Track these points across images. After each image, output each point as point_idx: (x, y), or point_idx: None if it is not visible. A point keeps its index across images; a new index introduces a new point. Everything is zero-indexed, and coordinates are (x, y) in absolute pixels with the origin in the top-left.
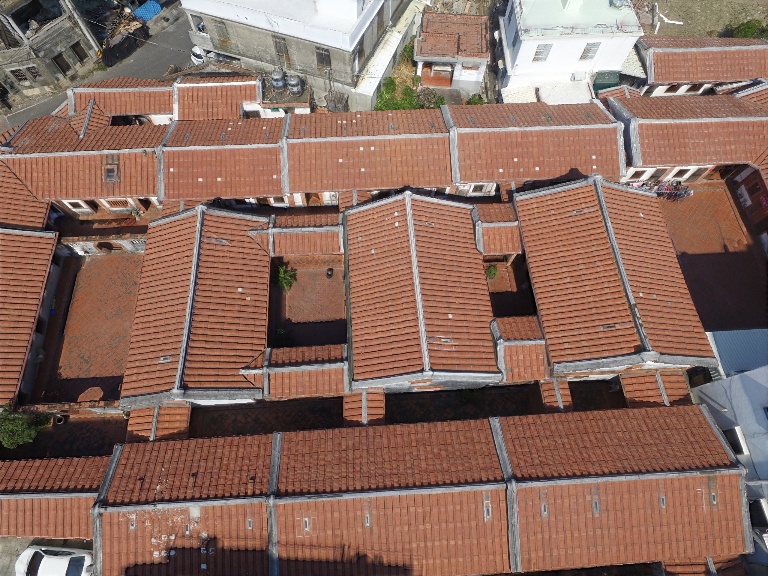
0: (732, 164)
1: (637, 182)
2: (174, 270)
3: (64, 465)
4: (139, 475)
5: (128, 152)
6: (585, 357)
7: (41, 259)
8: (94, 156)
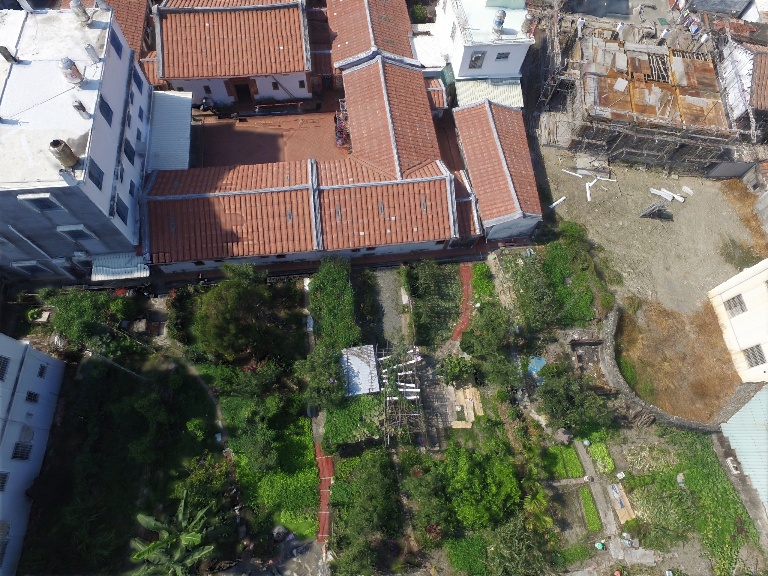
0: None
1: None
2: None
3: None
4: None
5: None
6: (170, 1)
7: None
8: None
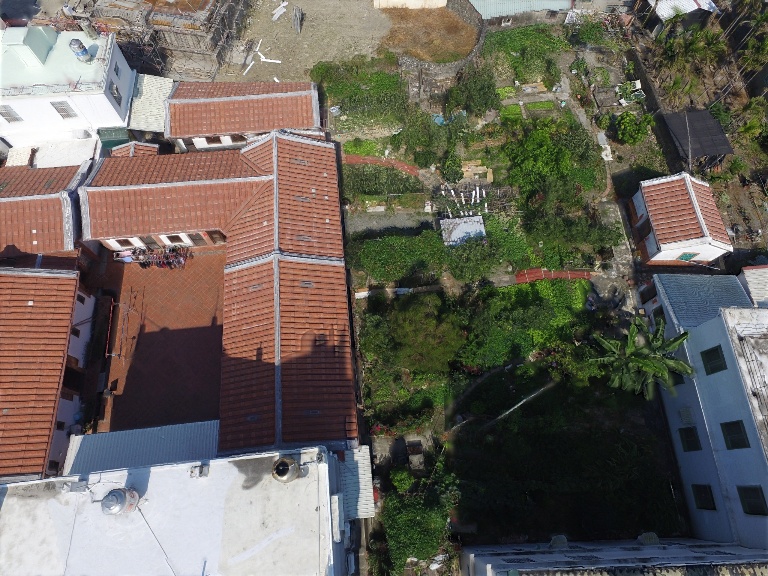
0: (206, 231)
1: (123, 251)
2: None
3: None
4: None
5: None
6: None
7: None
8: None
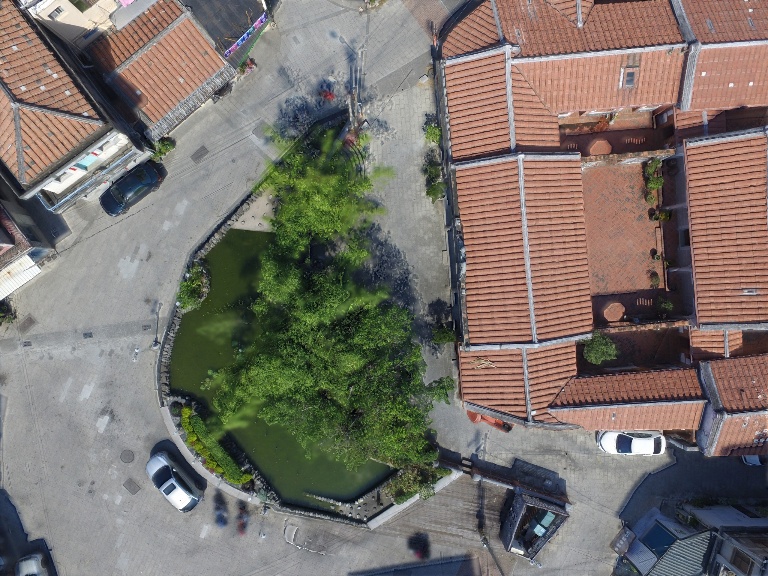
0: None
1: None
2: (738, 200)
3: (655, 378)
4: (737, 387)
5: (653, 50)
6: None
7: (577, 186)
8: (614, 56)
